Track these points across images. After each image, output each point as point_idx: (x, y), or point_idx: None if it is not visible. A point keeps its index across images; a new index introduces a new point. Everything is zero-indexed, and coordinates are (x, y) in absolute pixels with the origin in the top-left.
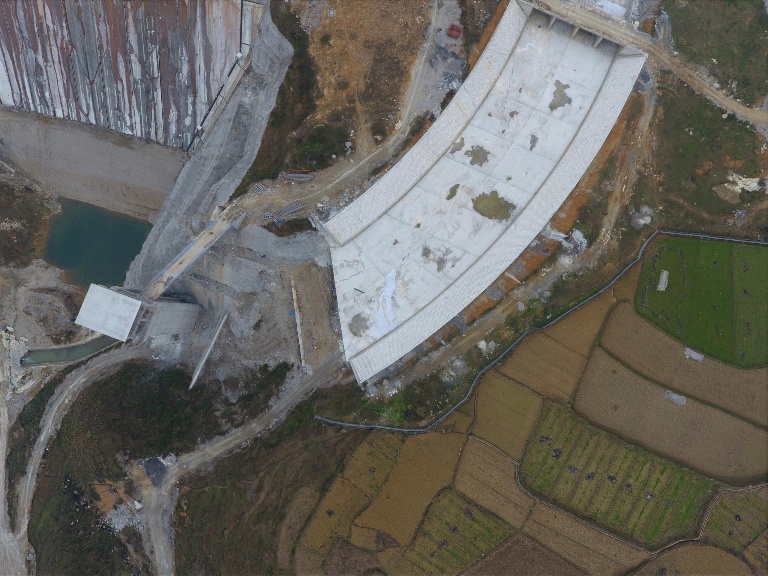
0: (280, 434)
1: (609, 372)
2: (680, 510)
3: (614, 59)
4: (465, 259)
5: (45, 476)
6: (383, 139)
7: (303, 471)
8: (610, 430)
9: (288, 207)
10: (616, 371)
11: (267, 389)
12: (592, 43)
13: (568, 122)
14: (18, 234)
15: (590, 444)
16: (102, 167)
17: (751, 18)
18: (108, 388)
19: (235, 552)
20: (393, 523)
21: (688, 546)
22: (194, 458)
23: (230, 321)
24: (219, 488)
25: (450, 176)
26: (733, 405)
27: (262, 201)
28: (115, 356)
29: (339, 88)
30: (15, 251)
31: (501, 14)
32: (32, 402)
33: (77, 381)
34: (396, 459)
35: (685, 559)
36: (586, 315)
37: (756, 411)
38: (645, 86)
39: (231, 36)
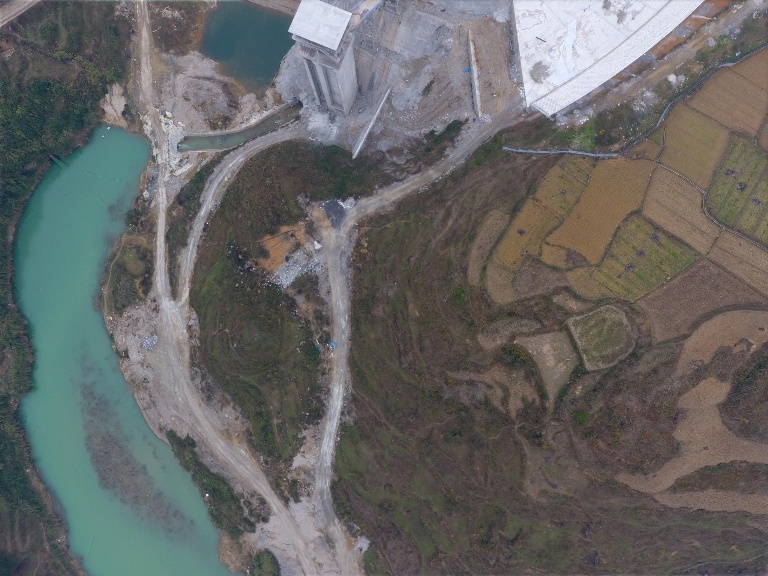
0: (465, 169)
1: None
2: None
3: None
4: (645, 12)
5: (206, 247)
6: None
7: (493, 196)
8: None
9: None
10: None
11: (439, 145)
12: None
13: None
14: (177, 23)
15: None
16: None
17: None
18: (279, 149)
19: (422, 275)
20: (583, 242)
21: None
22: (372, 202)
23: (392, 96)
24: (402, 222)
25: None
26: None
27: None
28: (273, 137)
29: None
30: (174, 39)
31: None
32: (190, 182)
33: (236, 160)
34: (587, 182)
35: None
36: None
37: None
38: None
39: None
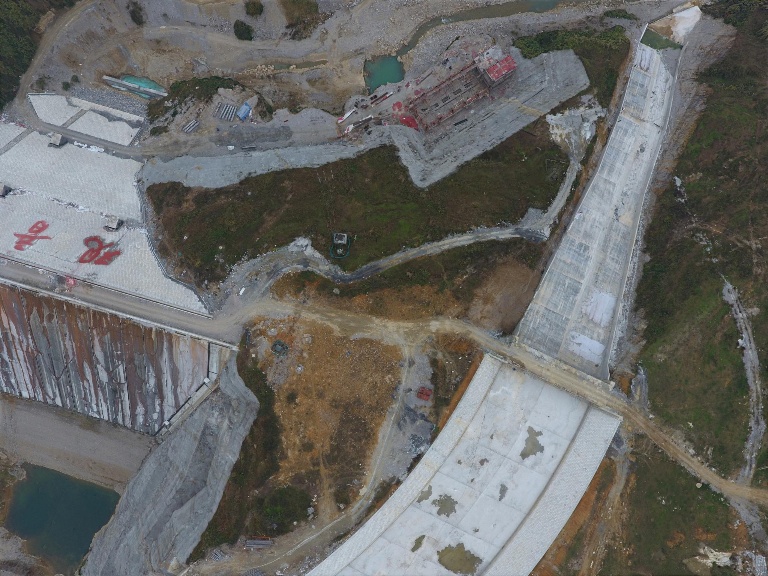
0: None
1: None
2: None
3: (589, 407)
4: None
5: None
6: (346, 506)
7: None
8: None
9: (246, 575)
10: None
11: None
12: None
13: (539, 472)
14: None
15: None
16: (68, 444)
17: (730, 379)
18: None
19: None
20: None
21: None
22: None
23: None
24: None
25: (416, 526)
26: None
27: (220, 568)
28: None
29: (304, 450)
30: None
31: (474, 372)
32: None
33: None
34: None
35: None
36: None
37: None
38: (618, 451)
39: (198, 365)
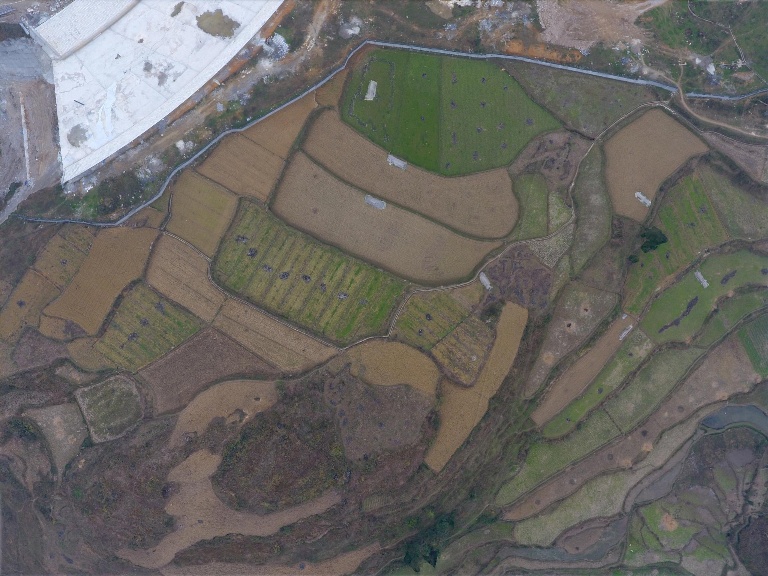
0: None
1: (310, 176)
2: (373, 310)
3: None
4: (186, 74)
5: None
6: None
7: (0, 266)
8: (308, 232)
9: None
10: (317, 175)
11: None
12: None
13: None
14: None
15: (286, 244)
16: None
17: None
18: None
19: None
20: (81, 313)
21: (374, 341)
22: None
23: None
24: None
25: None
26: (434, 211)
27: None
28: None
29: None
30: None
31: None
32: None
33: None
34: (87, 252)
35: (371, 354)
36: (287, 119)
37: (456, 218)
38: None
39: None
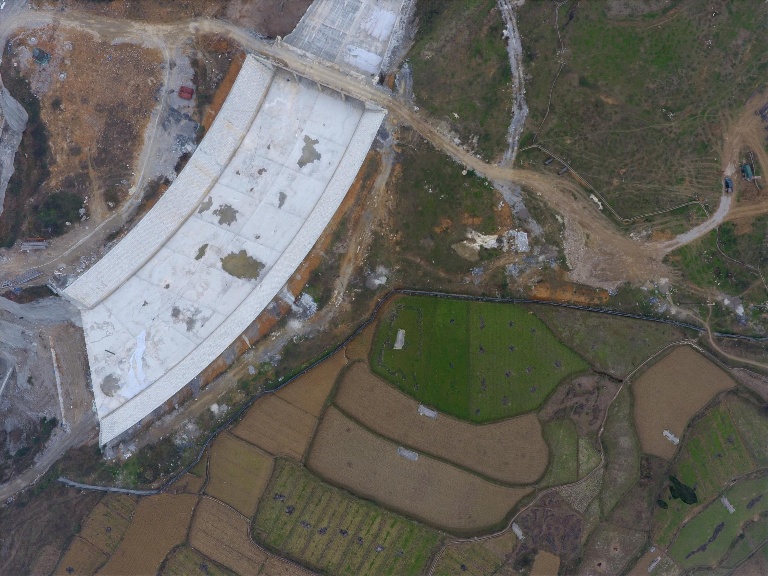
0: (32, 493)
1: (343, 430)
2: (409, 561)
3: (363, 113)
4: (214, 319)
5: None
6: (116, 205)
7: (46, 530)
8: (343, 486)
9: (24, 275)
10: (350, 429)
11: (37, 444)
12: (341, 96)
13: (317, 178)
14: None
15: (322, 500)
16: None
17: (495, 69)
18: None
19: None
20: None
21: None
22: None
23: (16, 373)
24: None
25: (198, 236)
26: (465, 459)
27: None
28: None
29: (72, 154)
30: None
31: (237, 72)
32: None
33: None
34: (130, 519)
35: None
36: (318, 376)
37: (488, 465)
38: (384, 143)
39: None
